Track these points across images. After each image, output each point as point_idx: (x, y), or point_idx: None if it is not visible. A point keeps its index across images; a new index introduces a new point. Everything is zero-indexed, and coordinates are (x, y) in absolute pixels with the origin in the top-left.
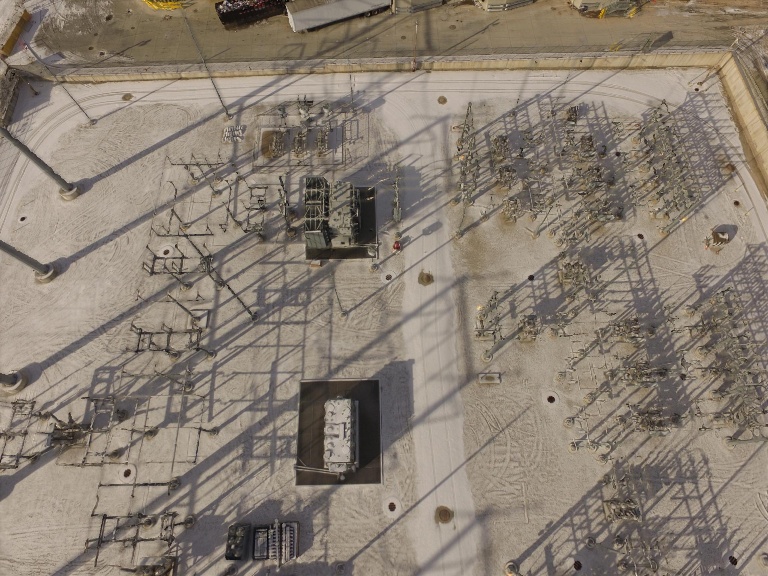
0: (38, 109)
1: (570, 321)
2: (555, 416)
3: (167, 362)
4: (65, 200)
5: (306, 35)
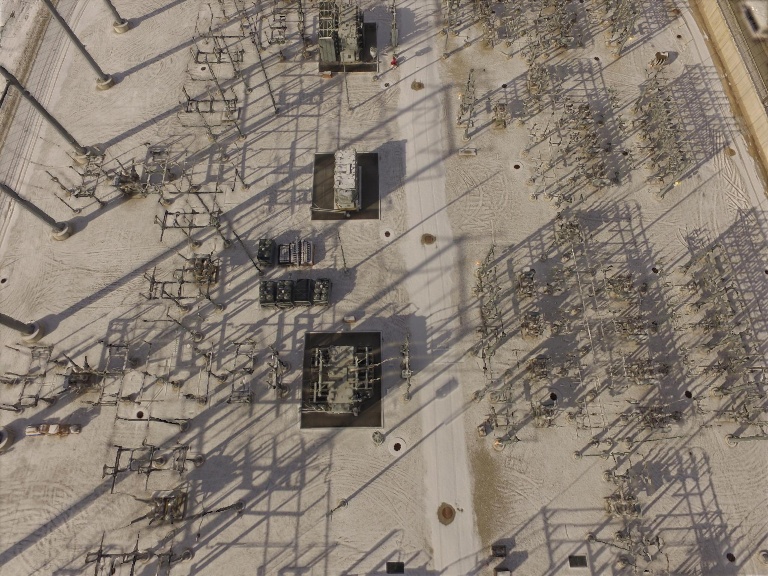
0: None
1: (535, 115)
2: (519, 178)
3: (207, 142)
4: (118, 33)
5: None
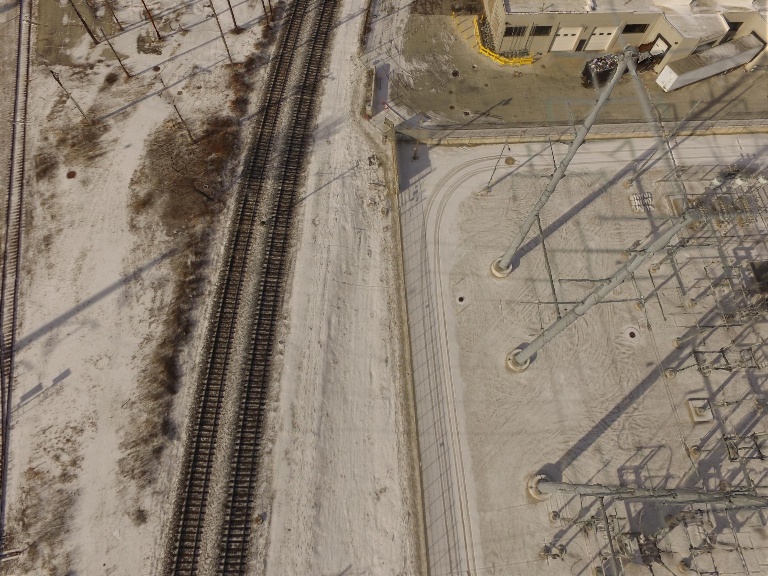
0: (423, 175)
1: None
2: None
3: None
4: (498, 277)
5: (670, 94)
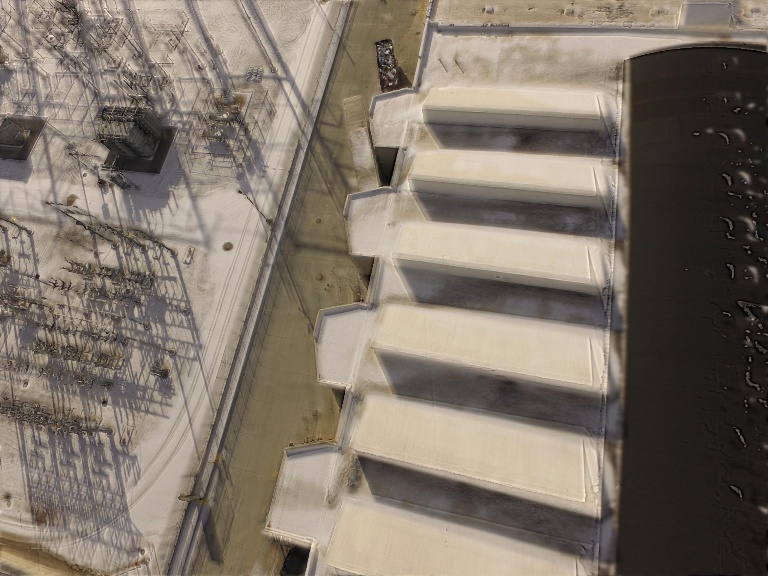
0: None
1: None
2: None
3: None
4: None
5: None
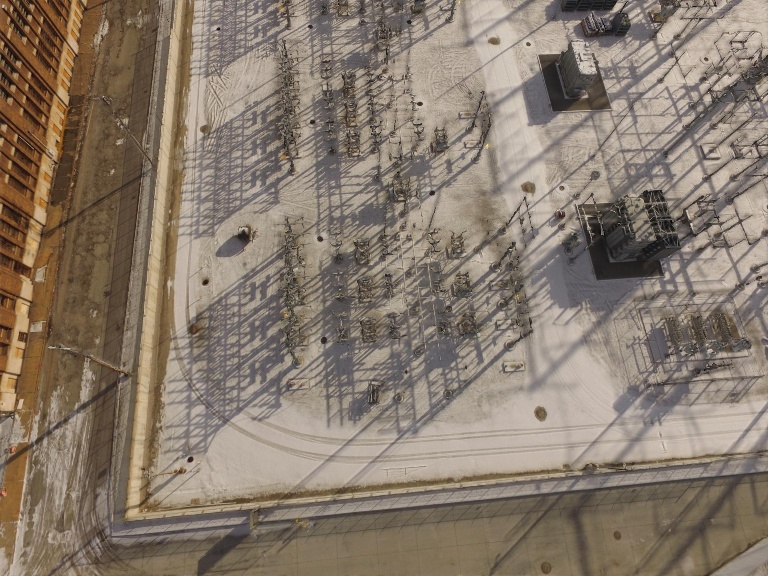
0: None
1: None
2: (418, 94)
3: None
4: None
5: (763, 534)
